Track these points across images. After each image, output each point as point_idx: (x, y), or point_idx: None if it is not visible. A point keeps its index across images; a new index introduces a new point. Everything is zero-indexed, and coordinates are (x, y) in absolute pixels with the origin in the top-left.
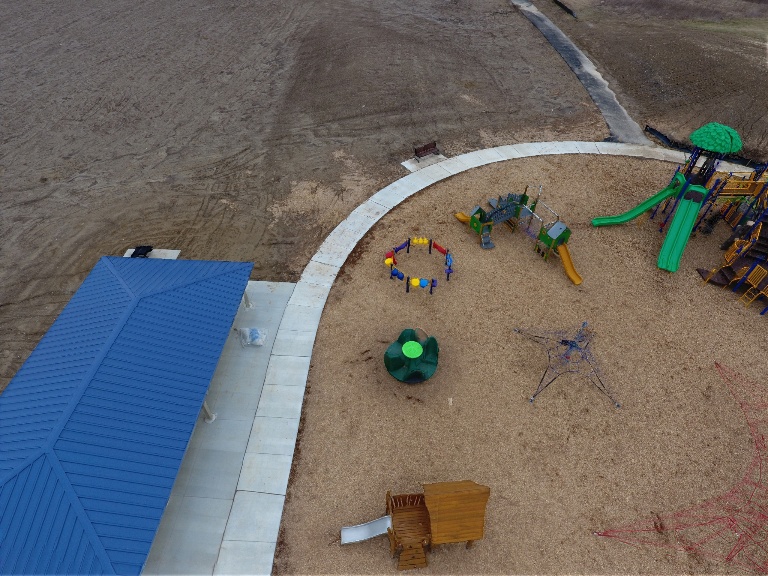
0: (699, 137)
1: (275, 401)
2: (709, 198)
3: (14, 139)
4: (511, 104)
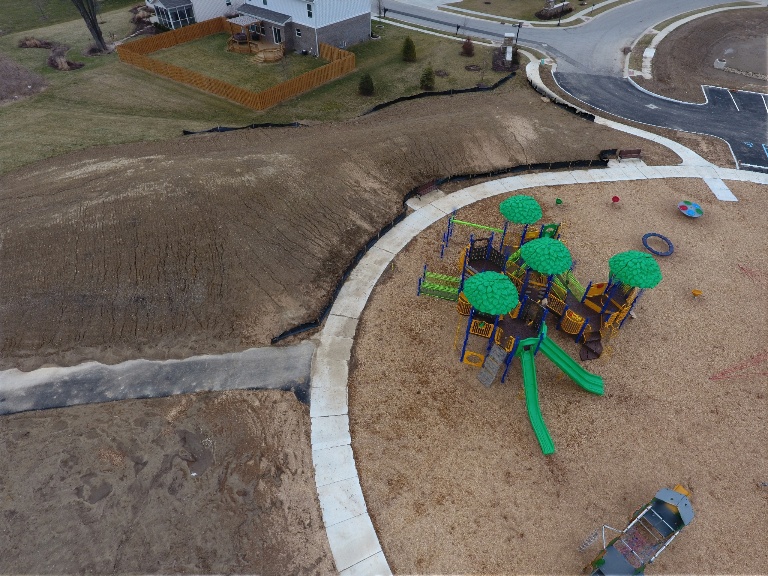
0: (502, 306)
1: None
2: (537, 324)
3: None
4: (165, 568)
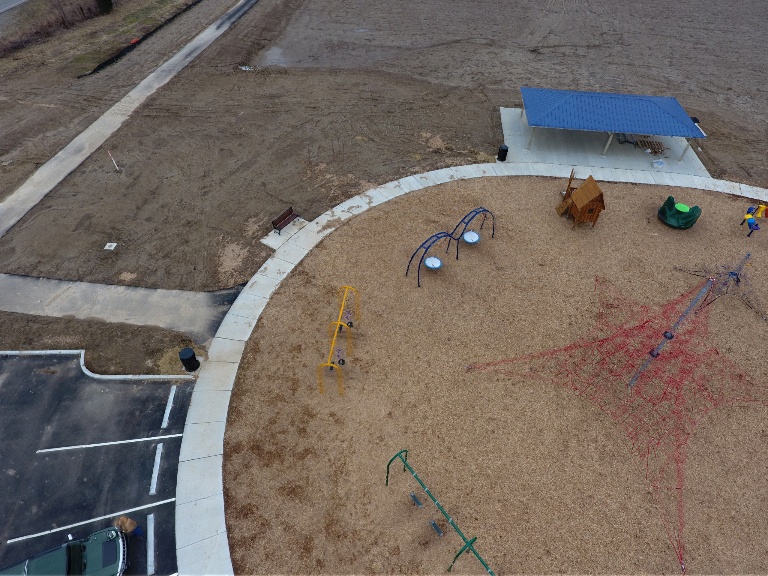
0: None
1: (621, 173)
2: None
3: (759, 72)
4: None
